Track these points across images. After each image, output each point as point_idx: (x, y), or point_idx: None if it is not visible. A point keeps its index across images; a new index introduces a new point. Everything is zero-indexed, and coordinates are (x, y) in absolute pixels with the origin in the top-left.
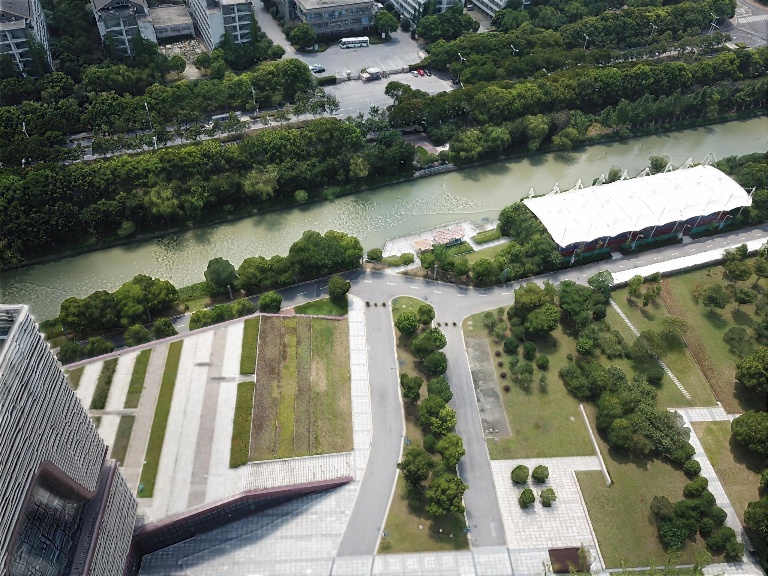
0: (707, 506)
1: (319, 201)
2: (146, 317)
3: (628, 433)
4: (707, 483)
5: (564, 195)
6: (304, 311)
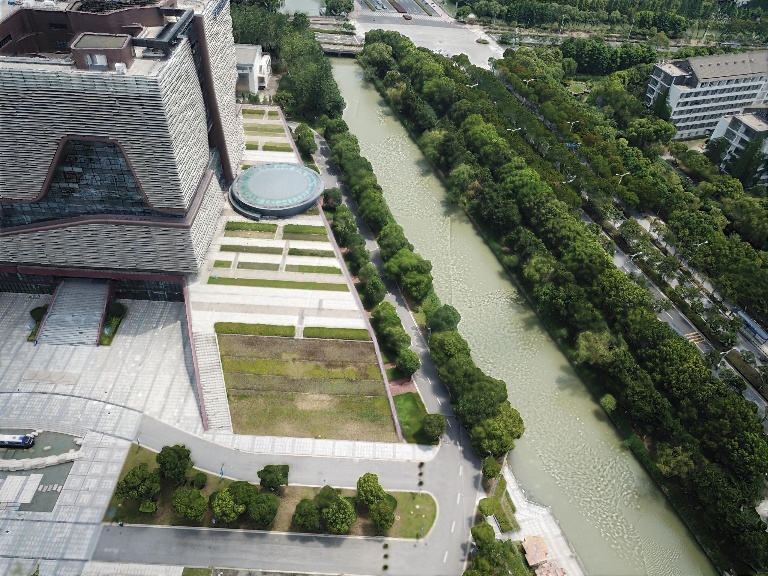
0: None
1: (620, 433)
2: None
3: None
4: None
5: None
6: (409, 399)
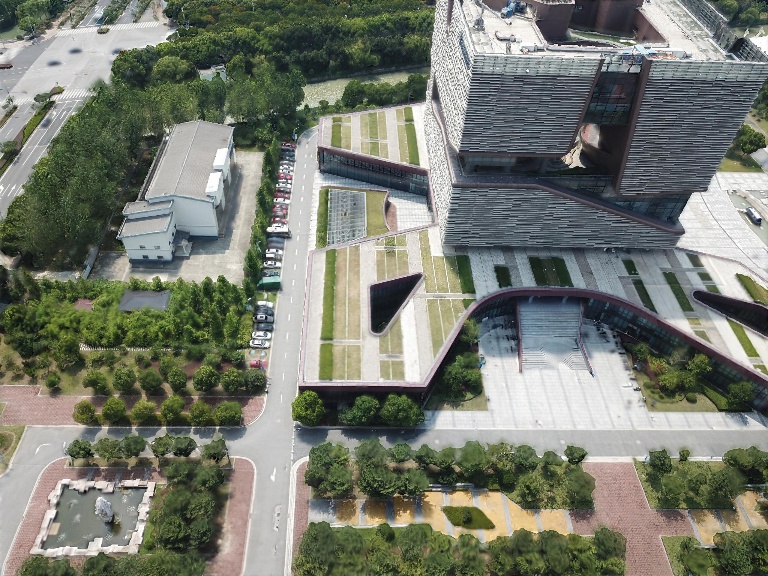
0: None
1: None
2: None
3: None
4: None
5: (766, 36)
6: None
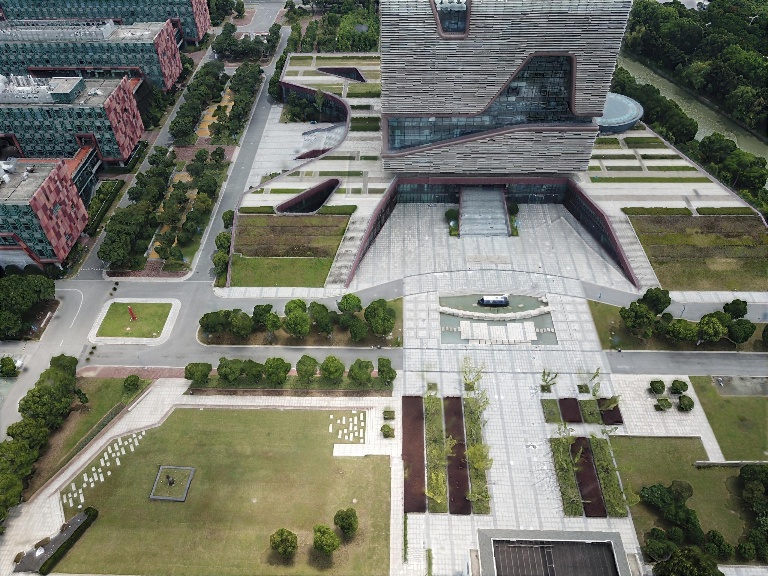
0: (696, 534)
1: None
2: (733, 181)
3: (759, 475)
4: (727, 550)
5: None
6: None
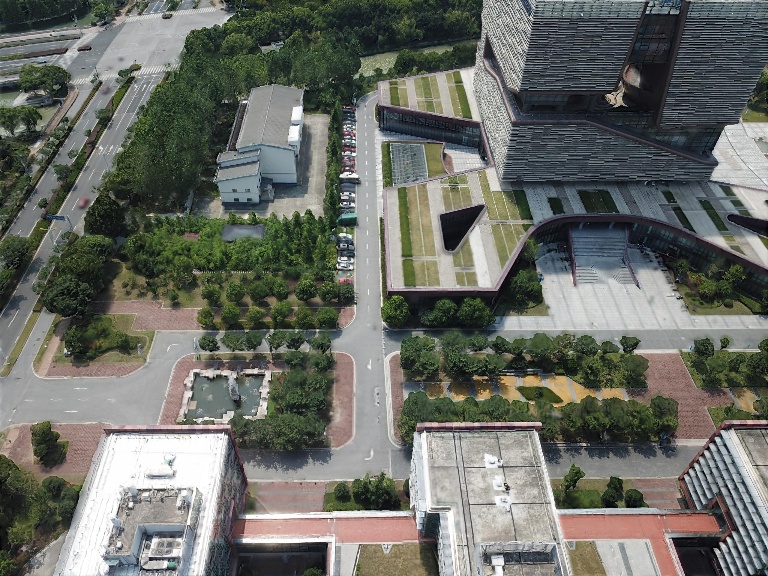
0: None
1: None
2: None
3: None
4: None
5: None
6: None
